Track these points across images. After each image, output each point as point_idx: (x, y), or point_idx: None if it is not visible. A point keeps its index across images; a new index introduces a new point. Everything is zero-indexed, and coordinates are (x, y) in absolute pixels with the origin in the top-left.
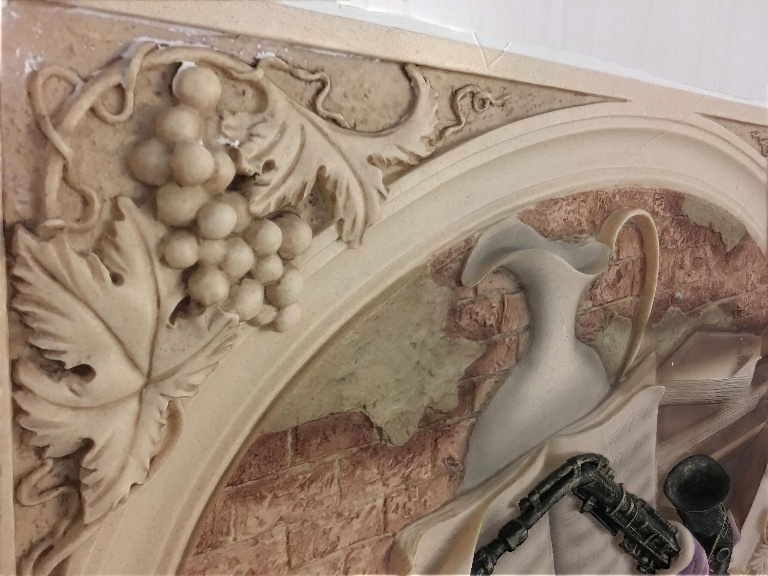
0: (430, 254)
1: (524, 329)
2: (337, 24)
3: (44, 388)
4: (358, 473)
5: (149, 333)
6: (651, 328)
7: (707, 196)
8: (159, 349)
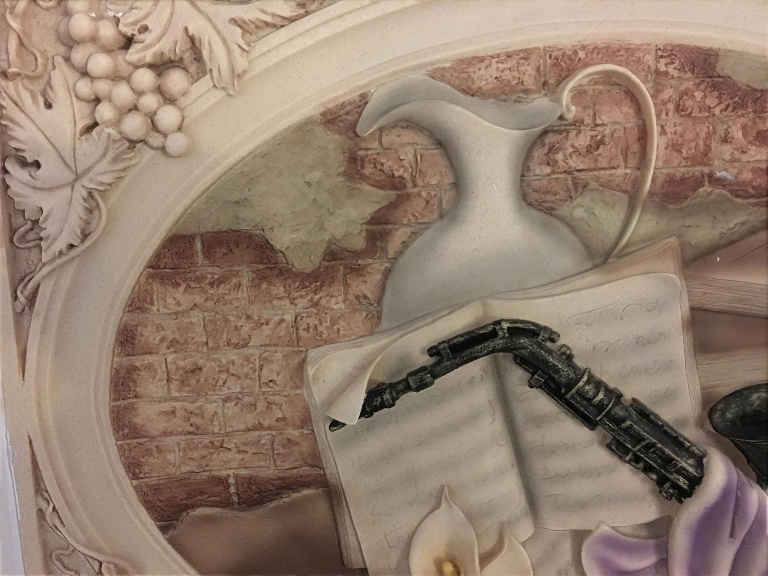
0: (320, 105)
1: (451, 187)
2: None
3: (15, 172)
4: (264, 286)
5: (70, 143)
6: (667, 209)
7: None
8: (77, 154)
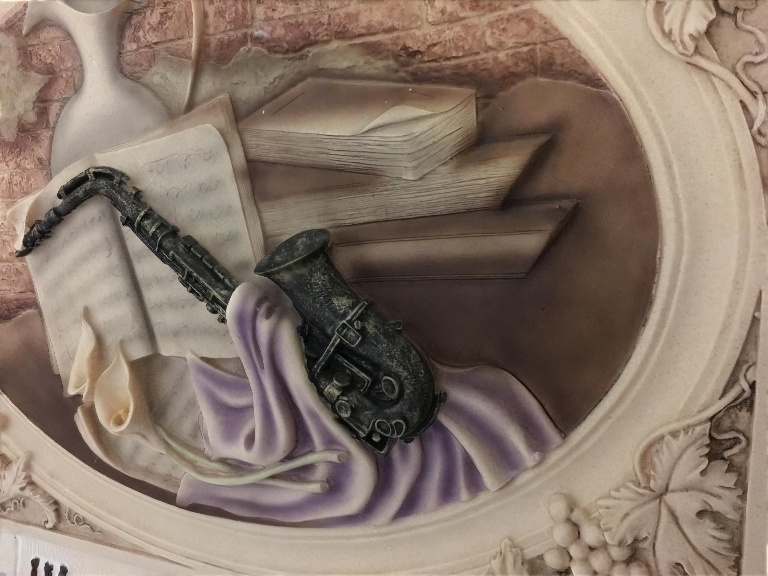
0: (5, 17)
1: None
2: None
3: None
4: None
5: None
6: (219, 70)
7: None
8: None
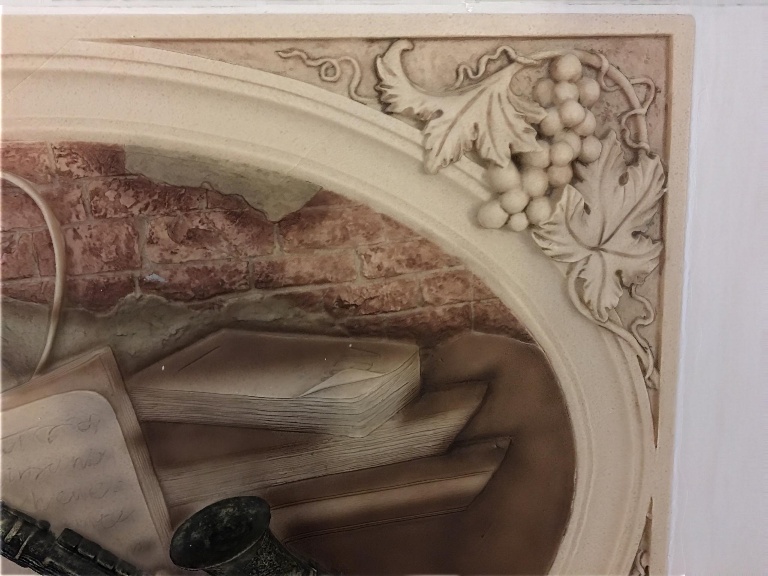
0: None
1: None
2: None
3: None
4: None
5: None
6: (94, 318)
7: (189, 146)
8: None
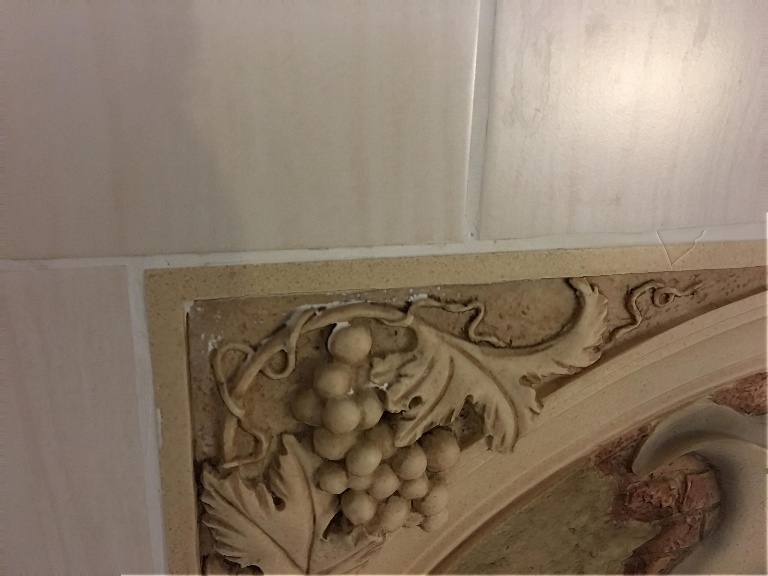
0: (595, 446)
1: (713, 506)
2: (491, 260)
3: None
4: None
5: (306, 544)
6: None
7: None
8: (315, 555)
